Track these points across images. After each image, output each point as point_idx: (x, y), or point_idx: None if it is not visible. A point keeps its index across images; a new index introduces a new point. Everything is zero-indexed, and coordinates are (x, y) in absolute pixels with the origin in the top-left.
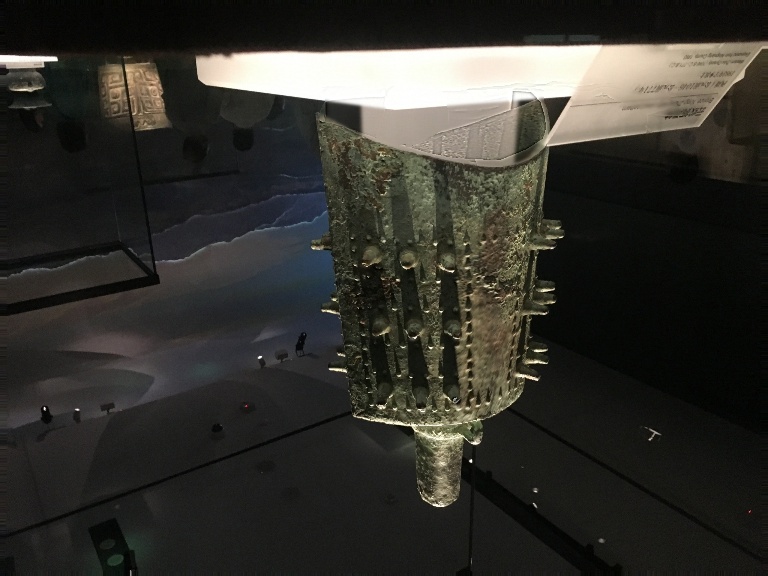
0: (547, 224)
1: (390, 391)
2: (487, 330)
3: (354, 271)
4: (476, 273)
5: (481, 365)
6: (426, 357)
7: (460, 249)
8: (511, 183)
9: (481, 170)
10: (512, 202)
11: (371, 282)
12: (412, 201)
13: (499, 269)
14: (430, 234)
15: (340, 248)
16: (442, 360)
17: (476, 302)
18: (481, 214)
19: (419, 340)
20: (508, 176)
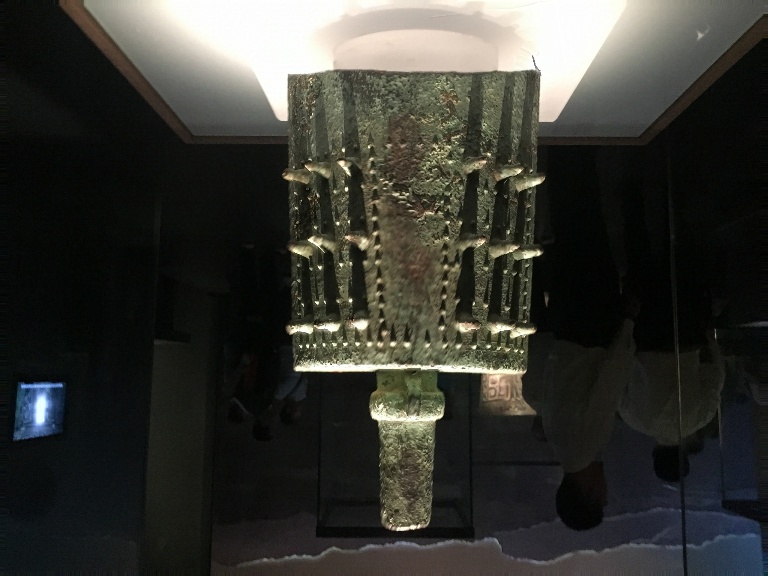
0: (524, 175)
1: (308, 321)
2: (400, 248)
3: (296, 201)
4: (383, 179)
5: (395, 291)
6: (338, 277)
7: (365, 153)
8: (420, 88)
9: (383, 74)
10: (424, 108)
11: (304, 206)
12: (327, 114)
13: (412, 178)
14: (340, 142)
15: (291, 183)
16: (352, 280)
17: (384, 212)
18: (385, 116)
19: (332, 257)
20: (415, 81)
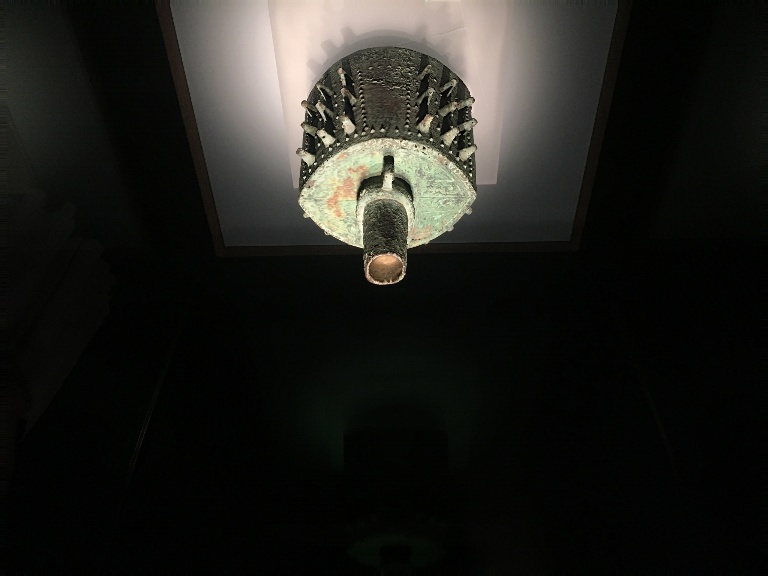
0: None
1: None
2: None
3: None
4: None
5: (374, 113)
6: None
7: None
8: None
9: (367, 49)
10: None
11: None
12: None
13: None
14: None
15: None
16: None
17: None
18: None
19: (331, 120)
20: None
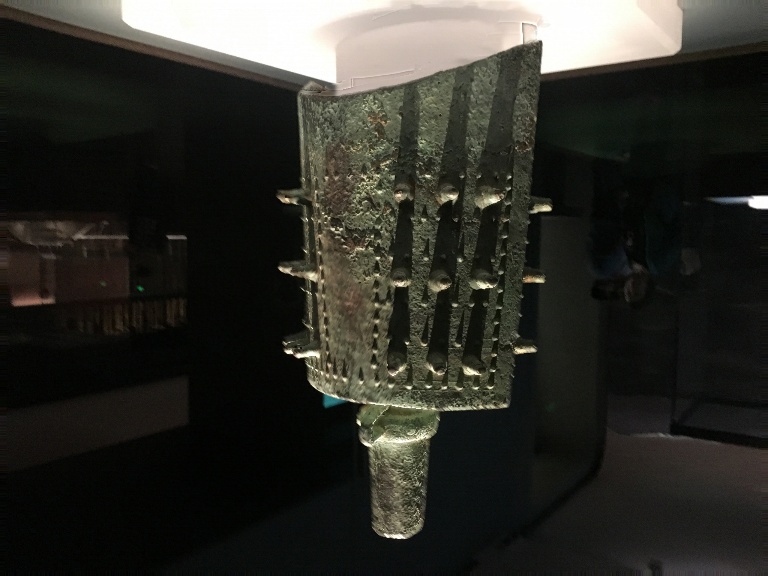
0: (483, 191)
1: (302, 337)
2: (338, 283)
3: None
4: (324, 212)
5: (336, 326)
6: (308, 303)
7: None
8: (348, 113)
9: (321, 100)
10: (352, 135)
11: None
12: None
13: (345, 212)
14: None
15: None
16: None
17: (326, 246)
18: (323, 147)
19: None
20: (344, 105)
